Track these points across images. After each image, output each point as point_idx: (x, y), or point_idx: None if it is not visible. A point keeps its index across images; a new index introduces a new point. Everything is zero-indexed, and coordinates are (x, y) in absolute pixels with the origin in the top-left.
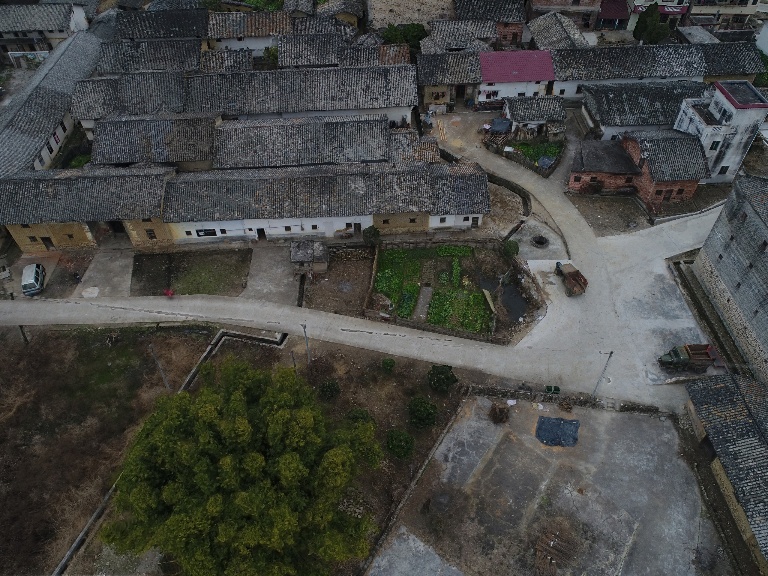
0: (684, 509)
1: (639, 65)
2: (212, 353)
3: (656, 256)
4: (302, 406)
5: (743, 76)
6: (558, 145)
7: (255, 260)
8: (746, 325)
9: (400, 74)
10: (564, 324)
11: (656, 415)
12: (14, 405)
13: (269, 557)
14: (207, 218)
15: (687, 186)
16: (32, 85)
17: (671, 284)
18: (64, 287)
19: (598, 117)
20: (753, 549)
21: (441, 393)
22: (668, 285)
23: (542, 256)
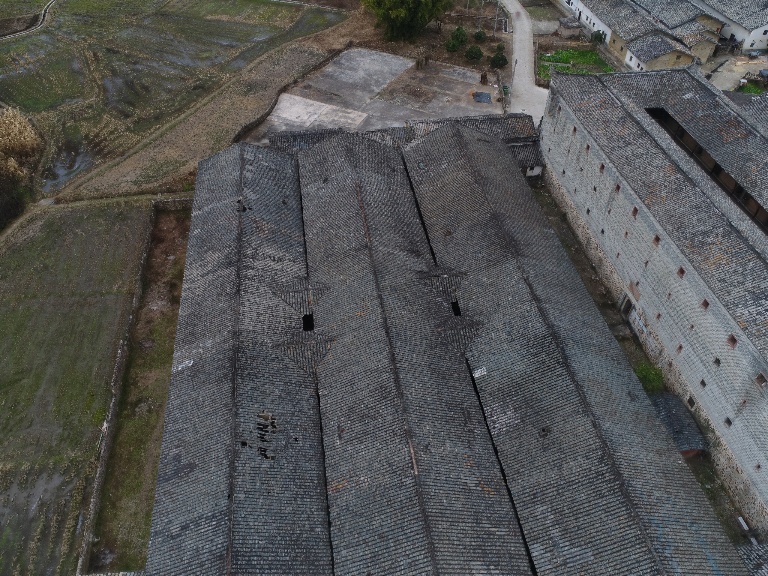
0: None
1: None
2: None
3: None
4: None
5: None
6: None
7: None
8: None
9: None
10: None
11: None
12: None
13: None
14: None
15: None
16: None
17: None
18: None
19: None
20: None
21: None
22: None
23: None
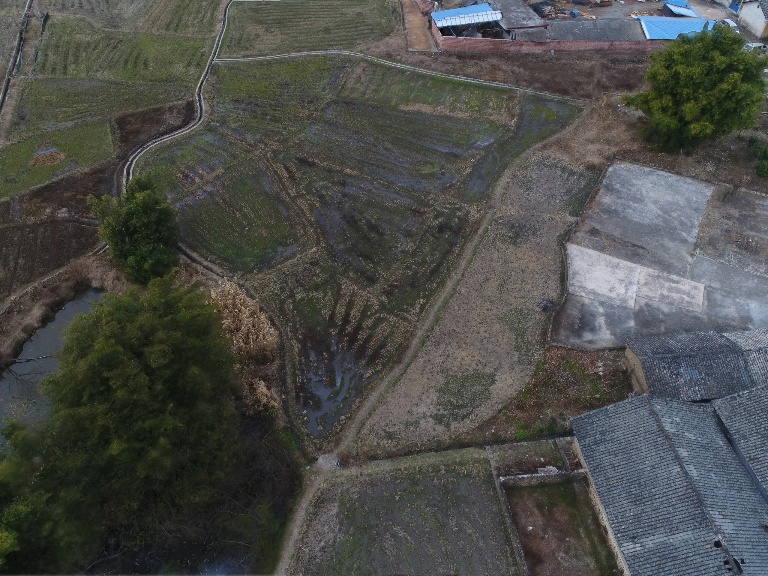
0: None
1: None
2: (765, 114)
3: None
4: (756, 79)
5: None
6: None
7: None
8: None
9: None
10: None
11: None
12: None
13: (672, 97)
14: None
15: None
16: None
17: None
18: None
19: None
20: None
21: None
22: None
23: None
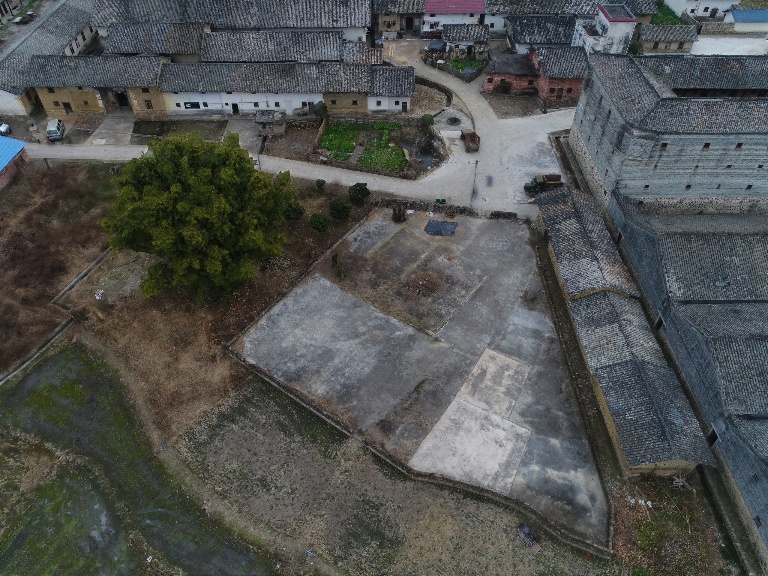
0: (522, 270)
1: (555, 4)
2: None
3: (541, 131)
4: None
5: (641, 17)
6: (483, 62)
7: (229, 127)
8: (593, 166)
9: (358, 3)
10: (460, 168)
11: (516, 221)
12: (39, 202)
13: (212, 243)
14: (193, 90)
15: (574, 85)
16: (59, 4)
17: (548, 148)
18: (79, 138)
19: (513, 37)
20: (563, 288)
21: (358, 203)
22: (546, 148)
23: (454, 130)
